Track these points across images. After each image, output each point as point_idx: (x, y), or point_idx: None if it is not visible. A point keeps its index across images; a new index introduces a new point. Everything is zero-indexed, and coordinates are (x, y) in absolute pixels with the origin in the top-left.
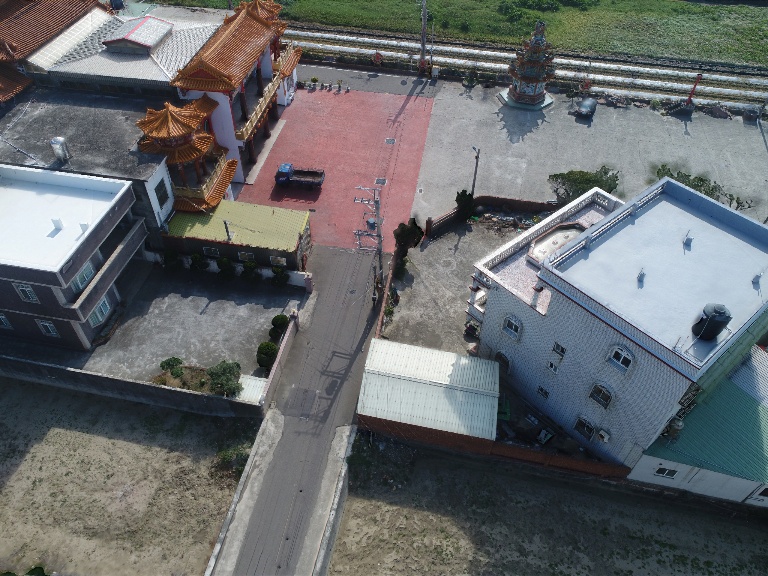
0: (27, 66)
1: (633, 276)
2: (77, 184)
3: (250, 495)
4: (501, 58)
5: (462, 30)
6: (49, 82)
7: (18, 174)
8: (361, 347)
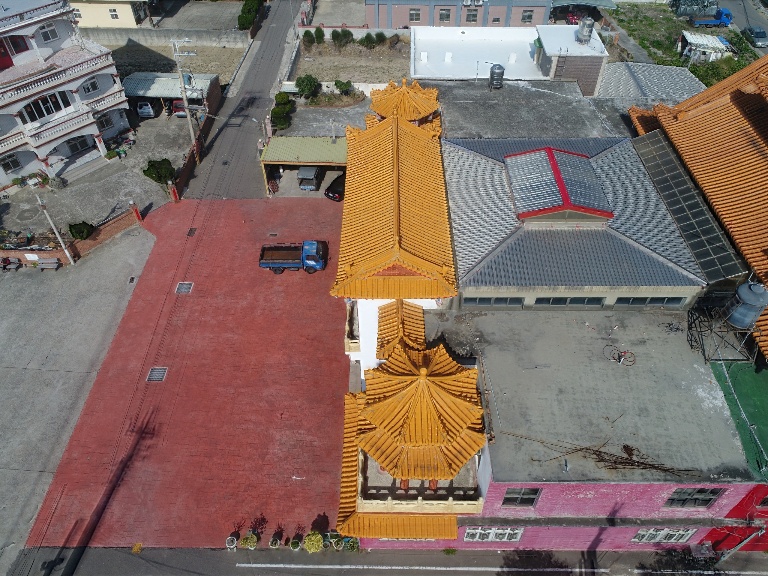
0: None
1: (7, 12)
2: None
3: None
4: None
5: None
6: None
7: None
8: (219, 131)
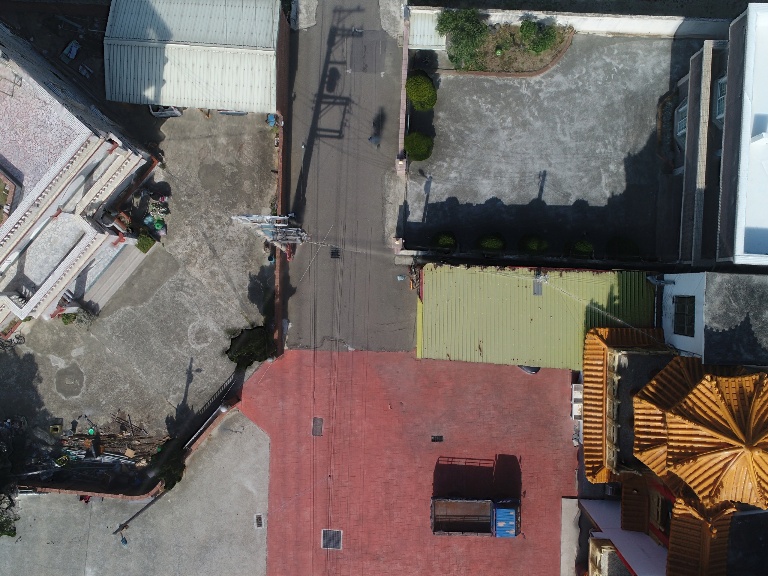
0: None
1: None
2: None
3: None
4: None
5: None
6: None
7: None
8: (306, 152)
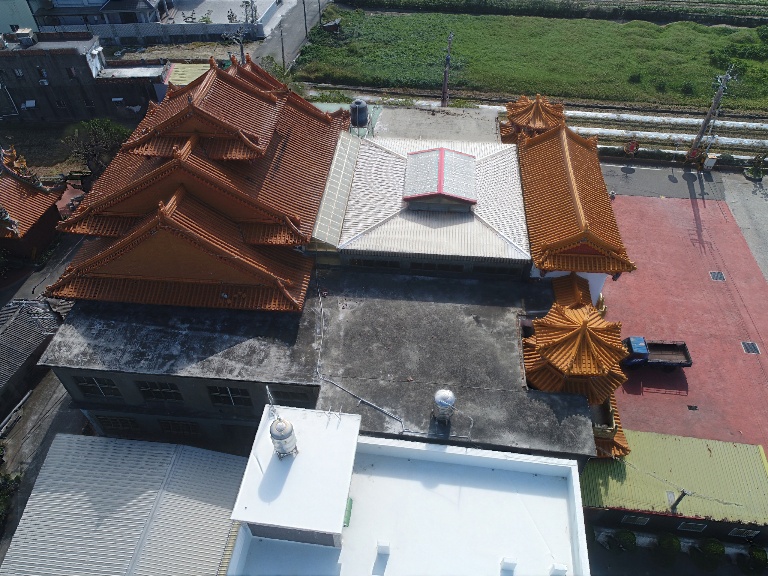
0: (309, 243)
1: None
2: (479, 462)
3: None
4: (755, 131)
5: (685, 93)
6: (334, 260)
7: (383, 450)
8: None
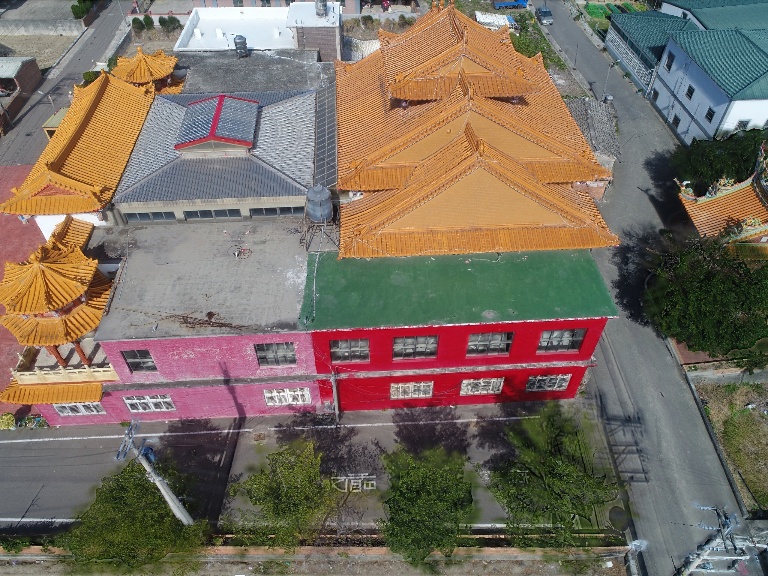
0: None
1: None
2: None
3: (106, 56)
4: None
5: None
6: None
7: None
8: (31, 107)
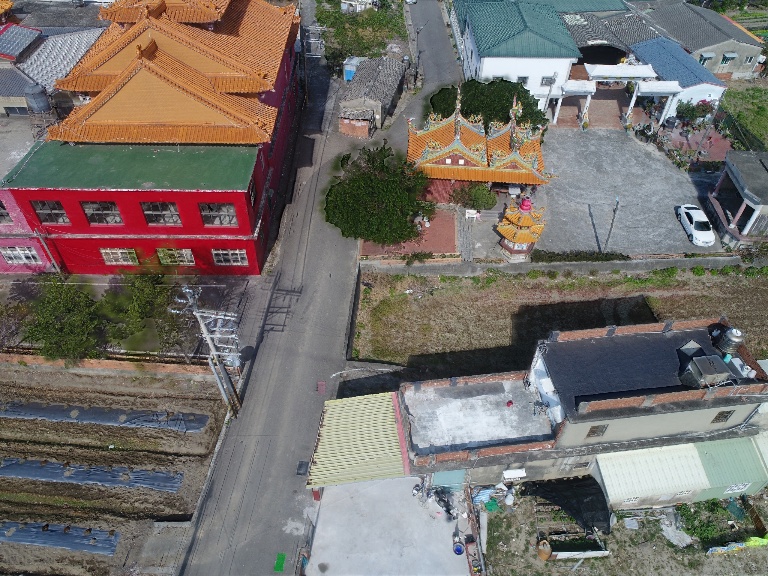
0: None
1: None
2: None
3: None
4: None
5: None
6: None
7: None
8: None
